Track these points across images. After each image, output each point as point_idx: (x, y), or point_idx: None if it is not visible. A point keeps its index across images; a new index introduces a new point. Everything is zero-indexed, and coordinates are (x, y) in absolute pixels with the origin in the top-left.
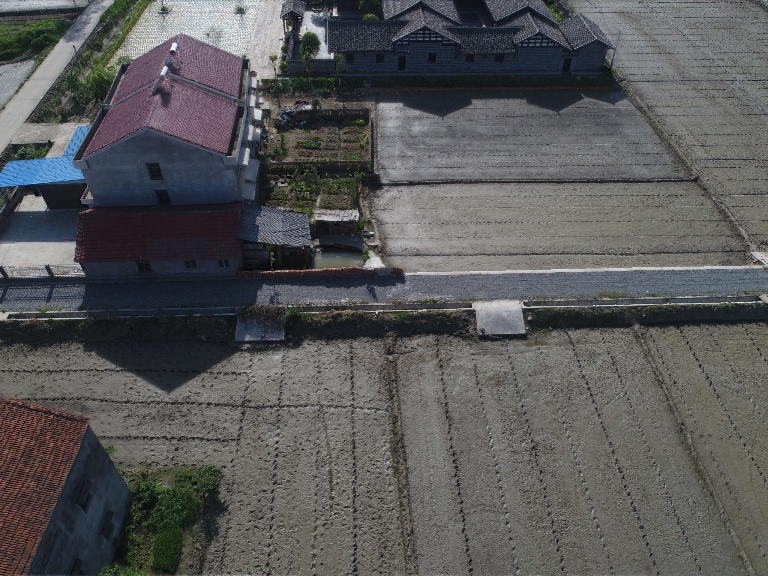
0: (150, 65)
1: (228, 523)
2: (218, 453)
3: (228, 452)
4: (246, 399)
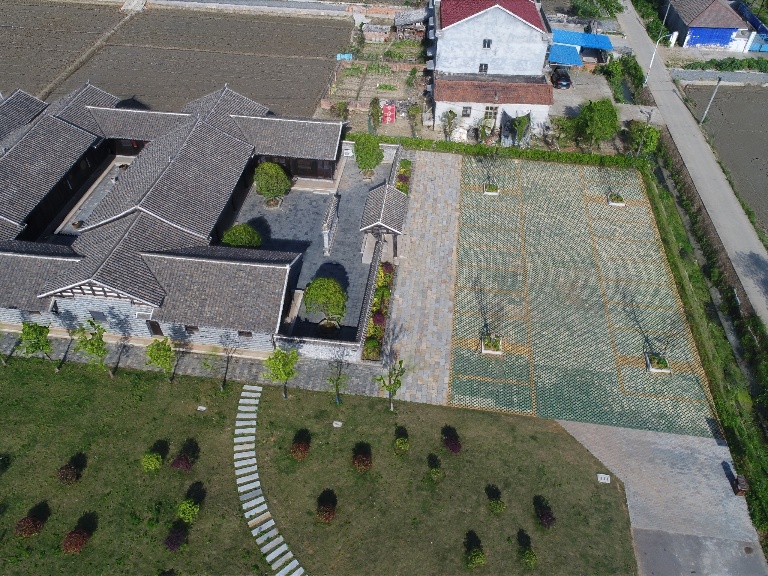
0: (515, 2)
1: None
2: None
3: None
4: None
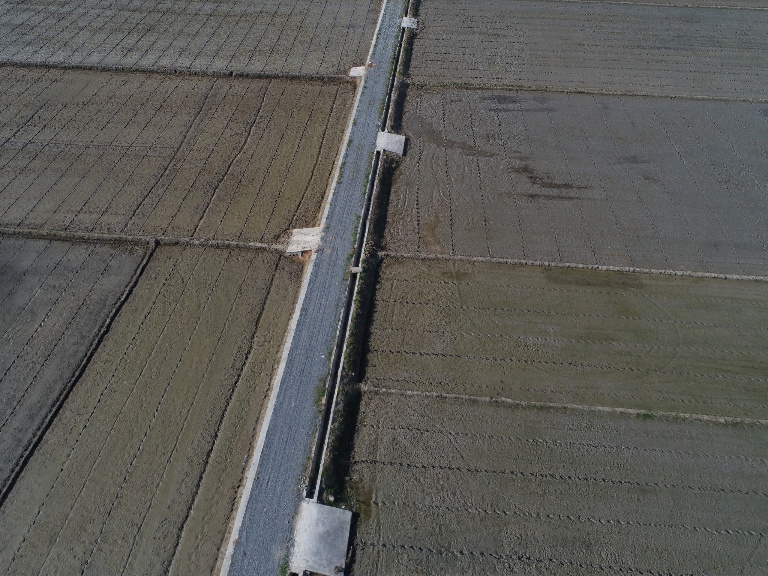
0: None
1: None
2: None
3: None
4: None
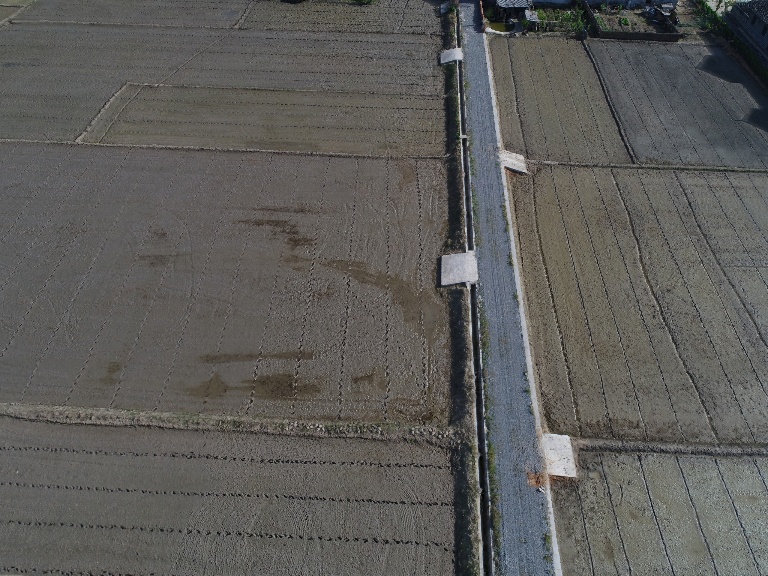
0: None
1: (354, 6)
2: (384, 4)
3: (384, 6)
4: (409, 8)
